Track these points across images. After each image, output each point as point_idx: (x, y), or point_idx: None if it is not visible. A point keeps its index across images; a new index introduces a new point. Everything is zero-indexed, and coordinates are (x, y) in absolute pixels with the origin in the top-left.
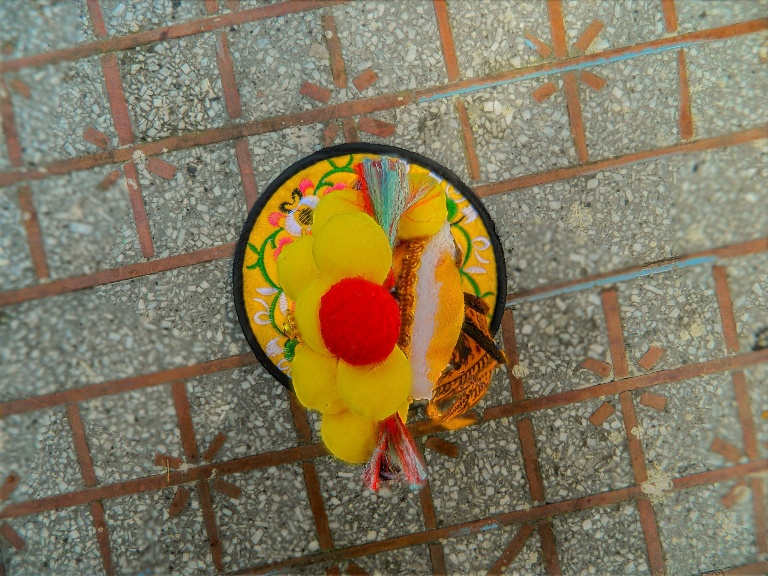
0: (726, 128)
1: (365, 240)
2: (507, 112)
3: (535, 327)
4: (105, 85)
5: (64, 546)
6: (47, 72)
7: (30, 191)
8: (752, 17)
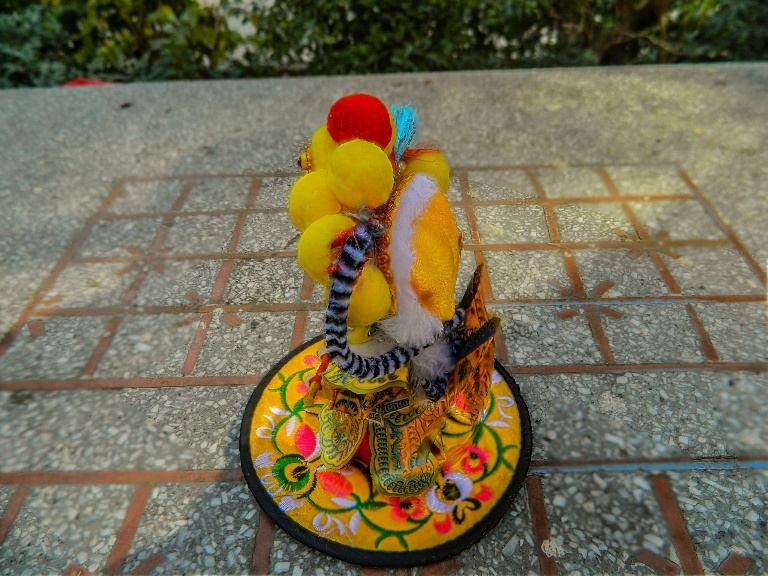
0: (753, 358)
1: None
2: (534, 322)
3: (569, 500)
4: (218, 273)
5: None
6: (183, 263)
7: (121, 320)
8: (748, 293)
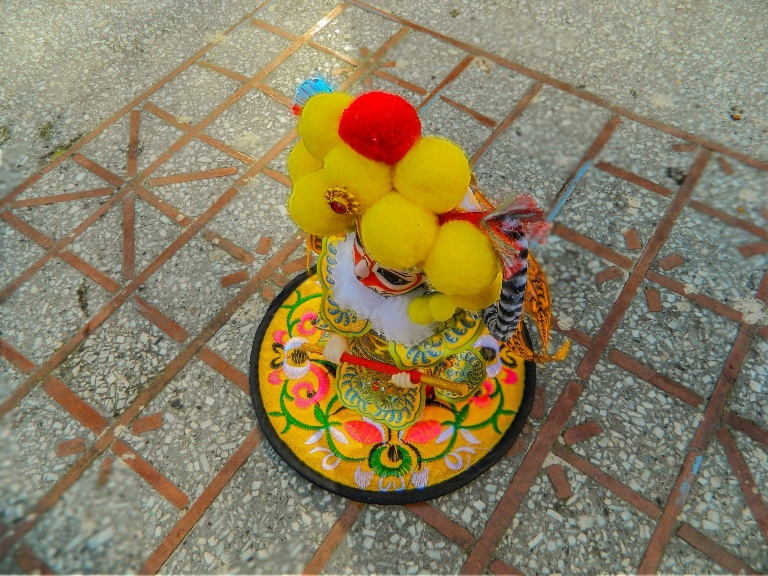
0: (509, 107)
1: None
2: None
3: None
4: (56, 402)
5: None
6: None
7: (27, 547)
8: (459, 61)
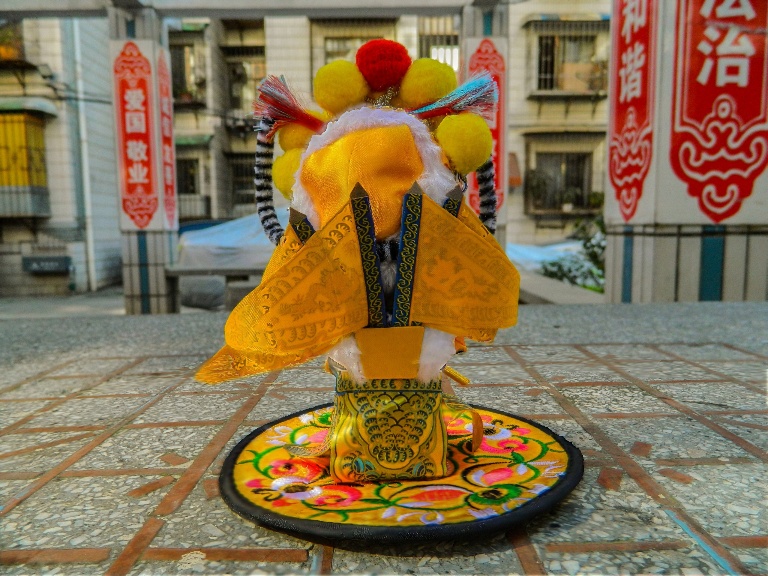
0: None
1: None
2: None
3: None
4: None
5: None
6: None
7: None
8: None
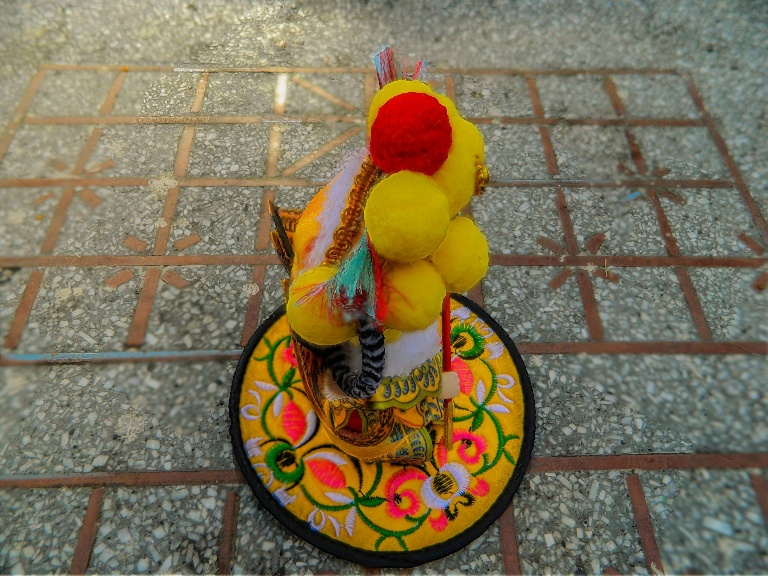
0: None
1: (392, 198)
2: (166, 573)
3: (222, 325)
4: None
5: (701, 228)
6: None
7: None
8: None
